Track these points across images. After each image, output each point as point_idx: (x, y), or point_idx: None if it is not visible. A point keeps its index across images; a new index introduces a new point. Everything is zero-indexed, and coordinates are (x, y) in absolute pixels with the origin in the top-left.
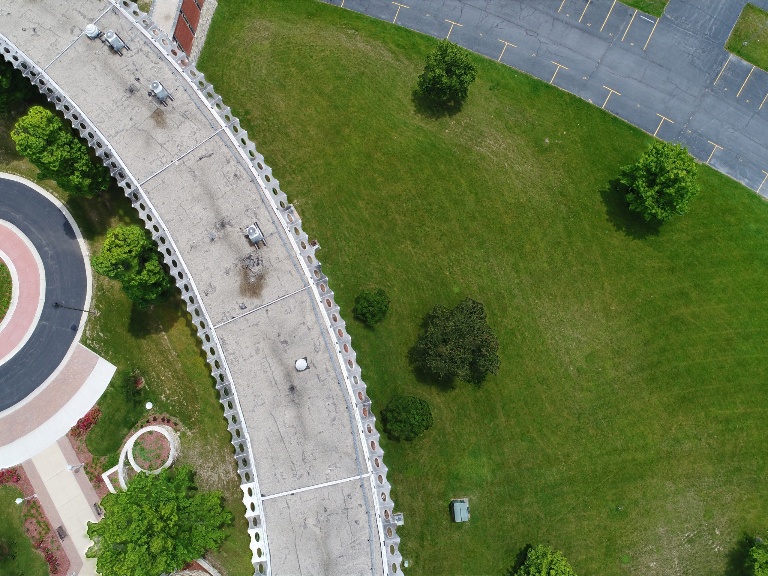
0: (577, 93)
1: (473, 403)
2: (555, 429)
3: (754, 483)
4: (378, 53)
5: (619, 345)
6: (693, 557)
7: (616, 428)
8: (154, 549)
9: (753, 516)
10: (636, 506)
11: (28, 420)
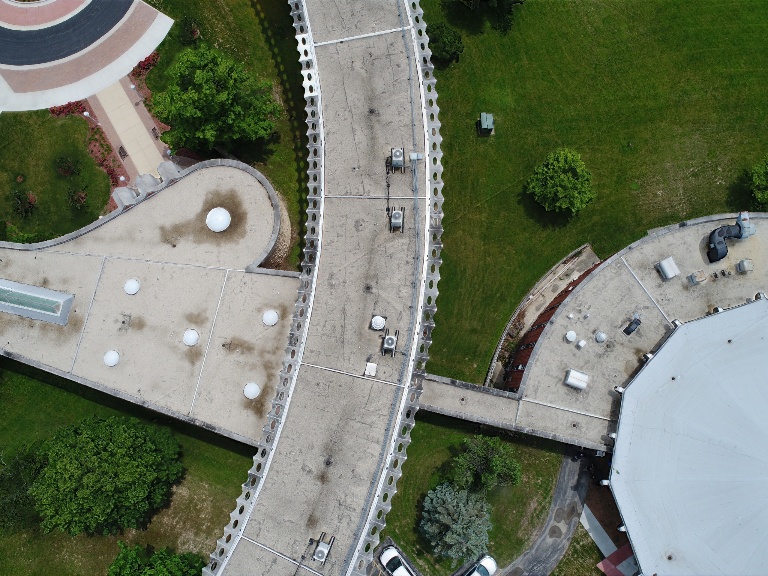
0: None
1: (499, 46)
2: (573, 75)
3: (754, 129)
4: None
5: (634, 11)
6: (697, 188)
7: (629, 79)
8: (220, 72)
9: (753, 157)
10: (646, 144)
11: (93, 63)
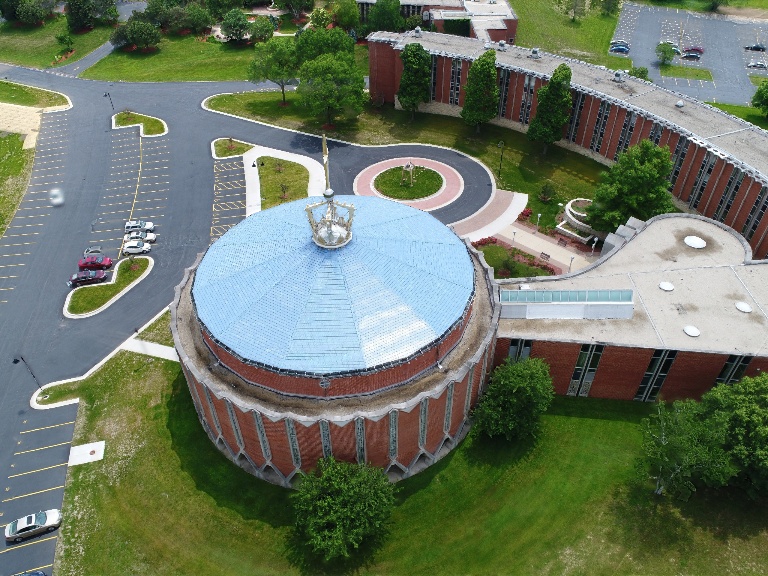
0: None
1: None
2: None
3: None
4: None
5: None
6: None
7: None
8: None
9: None
10: None
11: (485, 219)
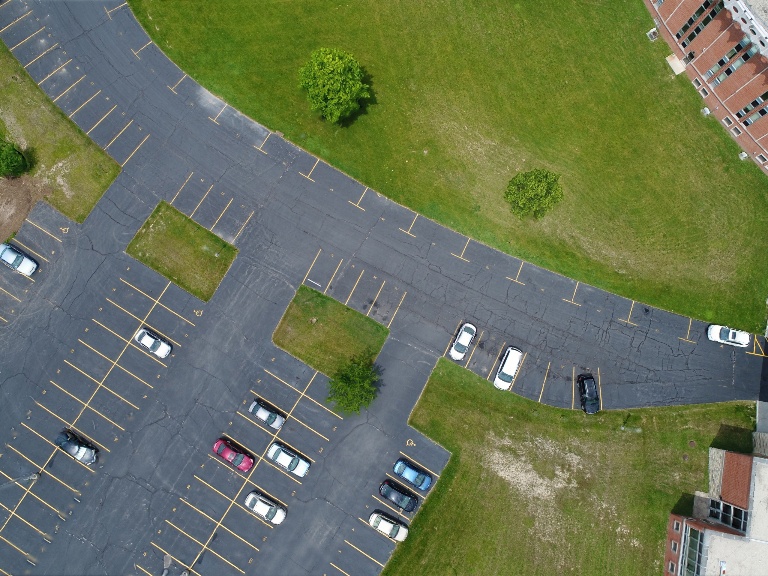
0: (392, 204)
1: None
2: None
3: None
4: (594, 245)
5: None
6: None
7: None
8: None
9: None
10: None
11: None
